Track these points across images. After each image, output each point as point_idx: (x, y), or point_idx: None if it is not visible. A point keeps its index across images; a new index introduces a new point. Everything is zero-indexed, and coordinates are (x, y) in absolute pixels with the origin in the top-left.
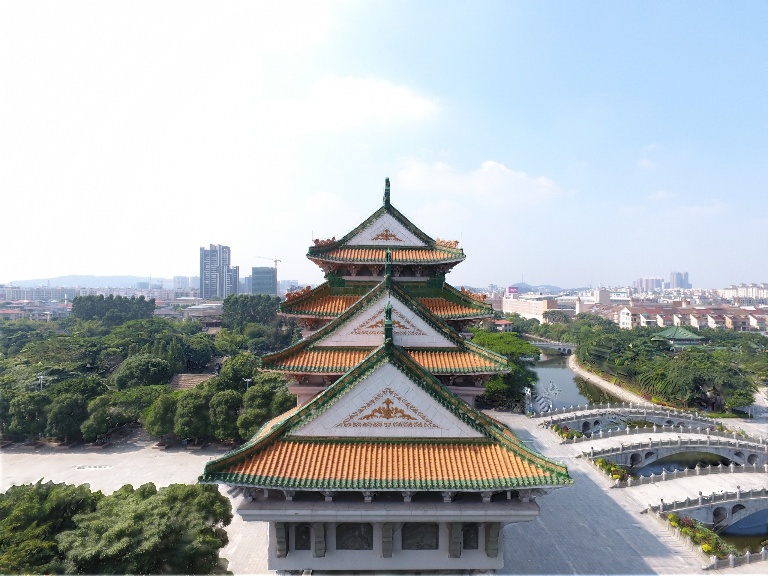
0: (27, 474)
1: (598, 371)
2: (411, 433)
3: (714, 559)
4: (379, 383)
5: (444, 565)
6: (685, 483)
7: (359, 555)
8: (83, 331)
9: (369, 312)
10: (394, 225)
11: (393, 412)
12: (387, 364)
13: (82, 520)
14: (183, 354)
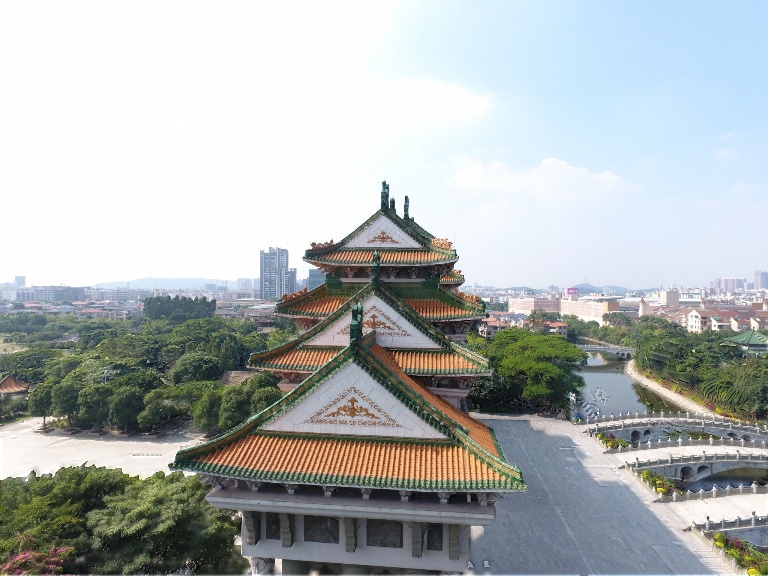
0: (90, 458)
1: (658, 377)
2: (375, 432)
3: None
4: (344, 382)
5: (408, 564)
6: (739, 501)
7: (326, 548)
8: (152, 329)
9: None
10: (390, 227)
11: (358, 411)
12: (352, 364)
13: (111, 501)
14: (236, 352)
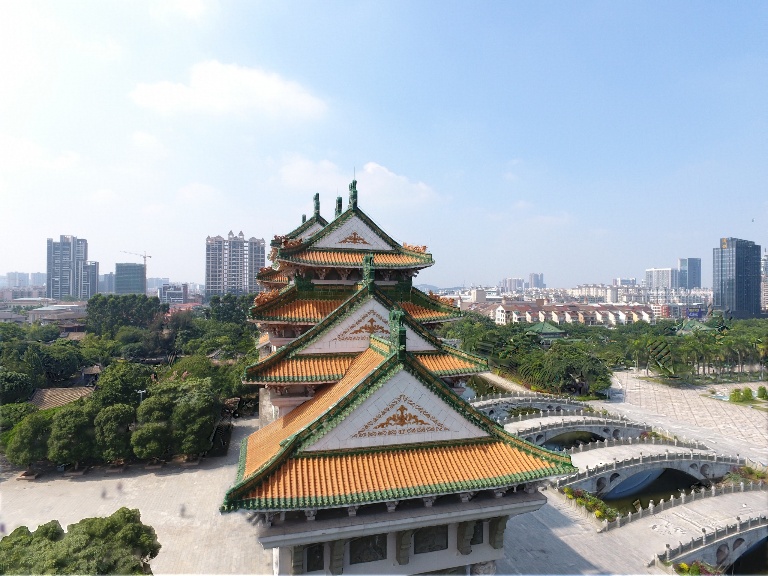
0: None
1: None
2: (424, 438)
3: (606, 522)
4: (394, 390)
5: (453, 563)
6: (573, 460)
7: (373, 567)
8: None
9: (353, 317)
10: (362, 228)
11: (407, 419)
12: (402, 371)
13: None
14: (41, 365)
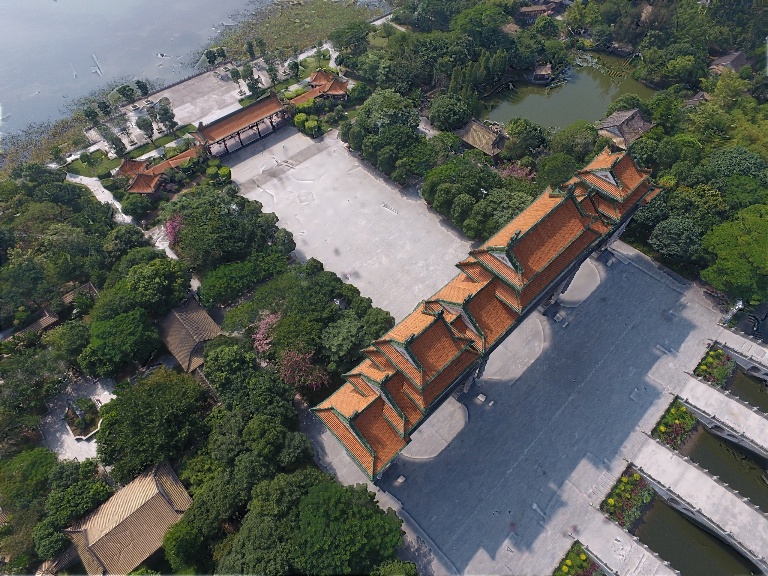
0: (363, 199)
1: None
2: None
3: (598, 507)
4: None
5: None
6: (691, 474)
7: None
8: None
9: None
10: None
11: None
12: None
13: (331, 327)
14: (507, 61)
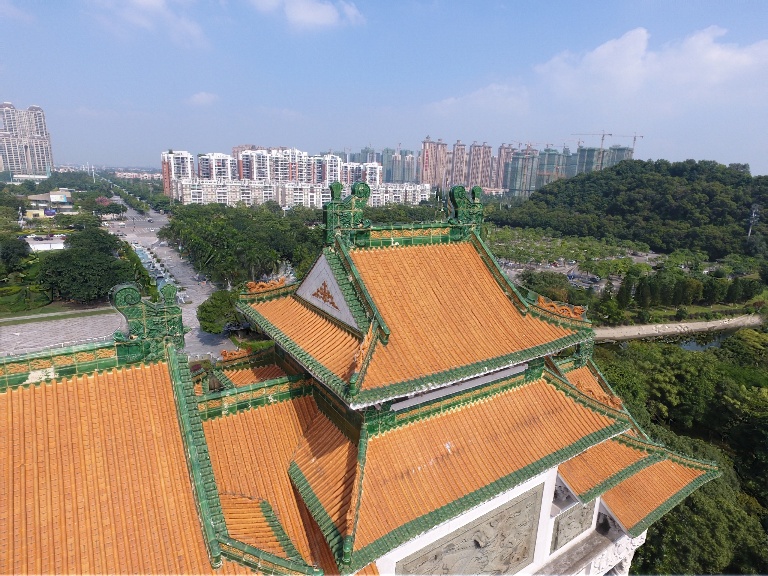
0: None
1: None
2: None
3: None
4: None
5: None
6: None
7: None
8: None
9: None
10: None
11: None
12: None
13: None
14: None
